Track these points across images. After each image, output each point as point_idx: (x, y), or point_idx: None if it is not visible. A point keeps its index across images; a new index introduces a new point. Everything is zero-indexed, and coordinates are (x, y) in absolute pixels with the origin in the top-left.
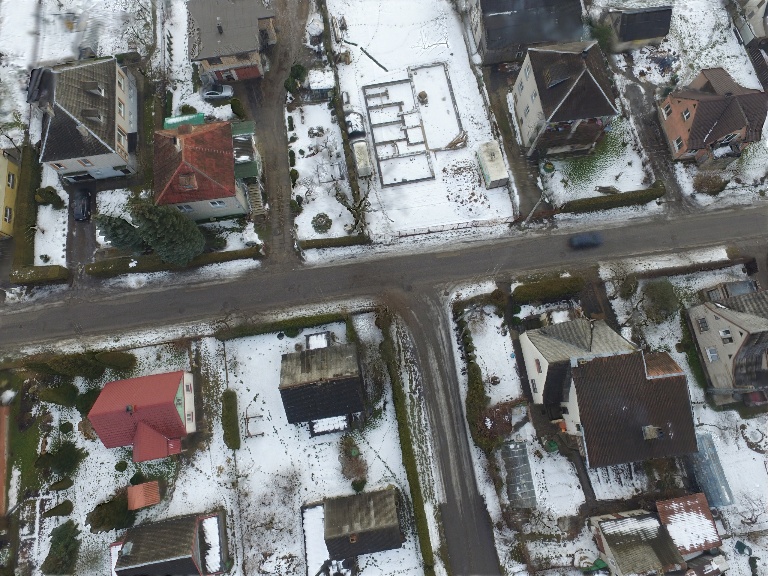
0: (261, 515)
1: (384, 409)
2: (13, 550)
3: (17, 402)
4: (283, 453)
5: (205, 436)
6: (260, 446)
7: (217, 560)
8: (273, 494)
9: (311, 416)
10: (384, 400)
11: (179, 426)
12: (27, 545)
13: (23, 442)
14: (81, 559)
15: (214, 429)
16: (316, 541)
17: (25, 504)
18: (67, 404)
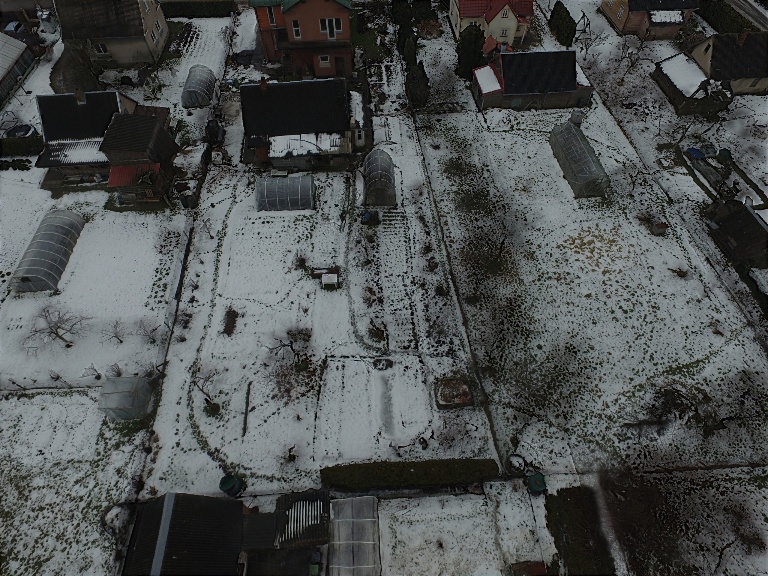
0: (609, 78)
1: (704, 30)
2: (364, 88)
3: (354, 21)
4: (616, 49)
5: (535, 40)
6: (591, 46)
7: (586, 81)
8: (616, 68)
9: (650, 6)
10: (702, 26)
11: (530, 1)
12: (377, 86)
13: (362, 39)
14: (433, 96)
15: (543, 37)
16: (684, 74)
17: (371, 65)
18: (400, 23)
